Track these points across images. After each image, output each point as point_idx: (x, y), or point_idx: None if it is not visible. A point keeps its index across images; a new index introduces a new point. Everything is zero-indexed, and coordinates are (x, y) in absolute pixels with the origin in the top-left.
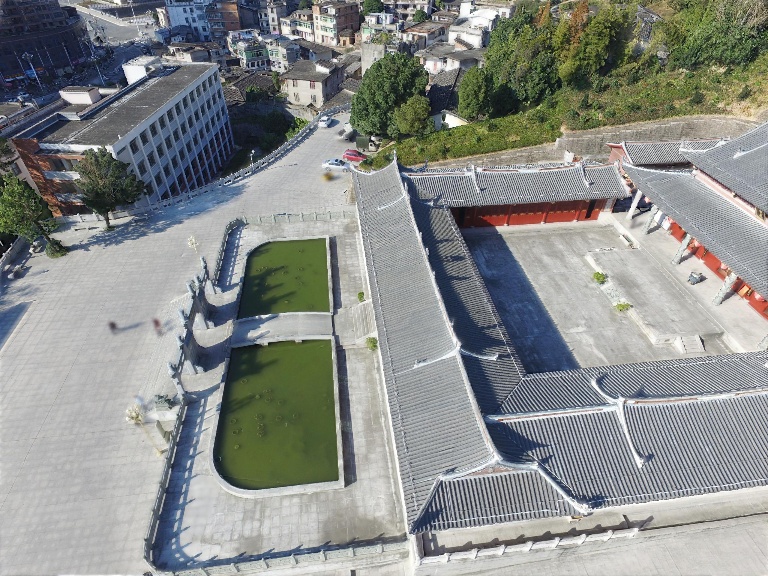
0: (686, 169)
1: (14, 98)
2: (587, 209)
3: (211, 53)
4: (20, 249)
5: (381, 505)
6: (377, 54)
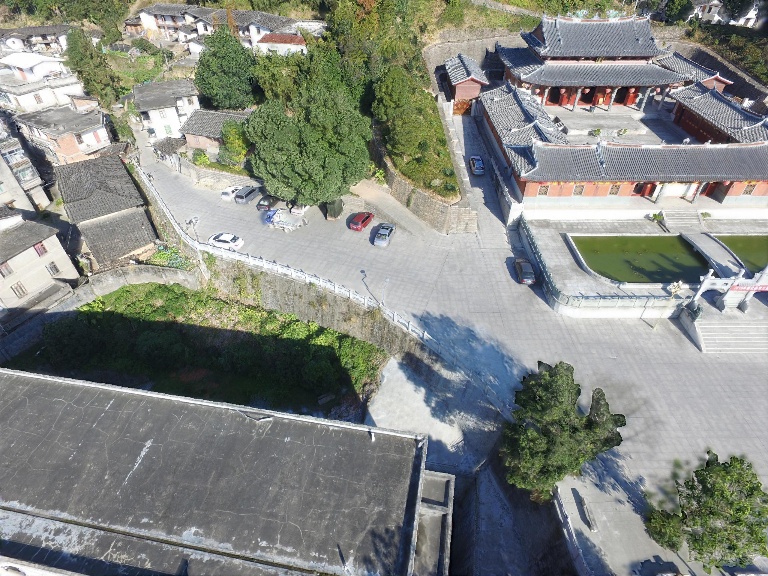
0: (515, 69)
1: None
2: None
3: None
4: None
5: None
6: None
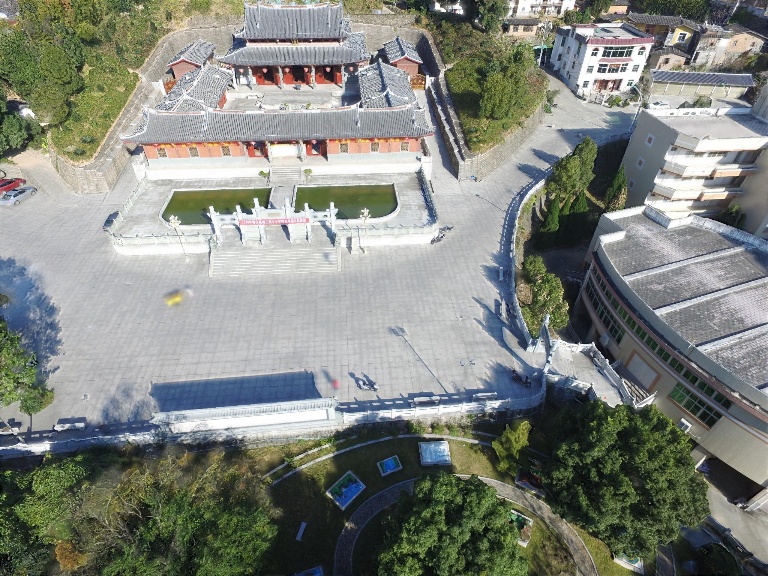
0: (229, 52)
1: None
2: (223, 94)
3: None
4: None
5: (403, 177)
6: None
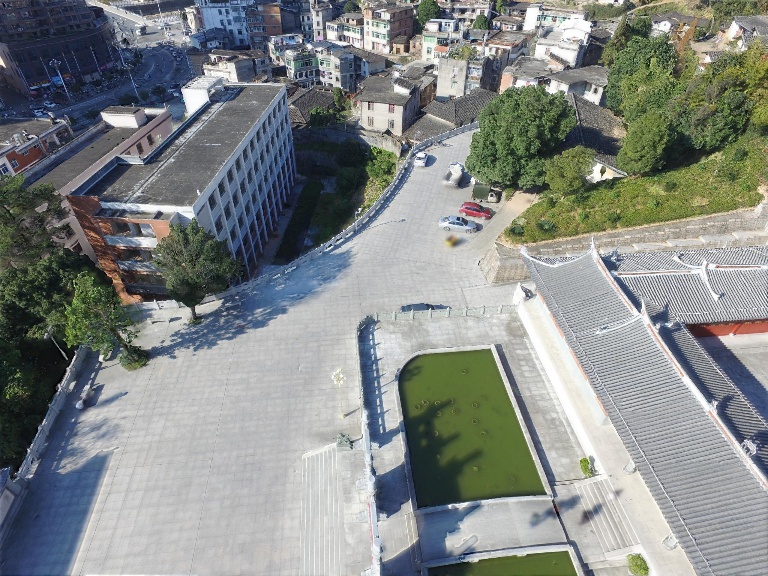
0: None
1: (40, 108)
2: None
3: (256, 62)
4: (85, 354)
5: None
6: (457, 71)
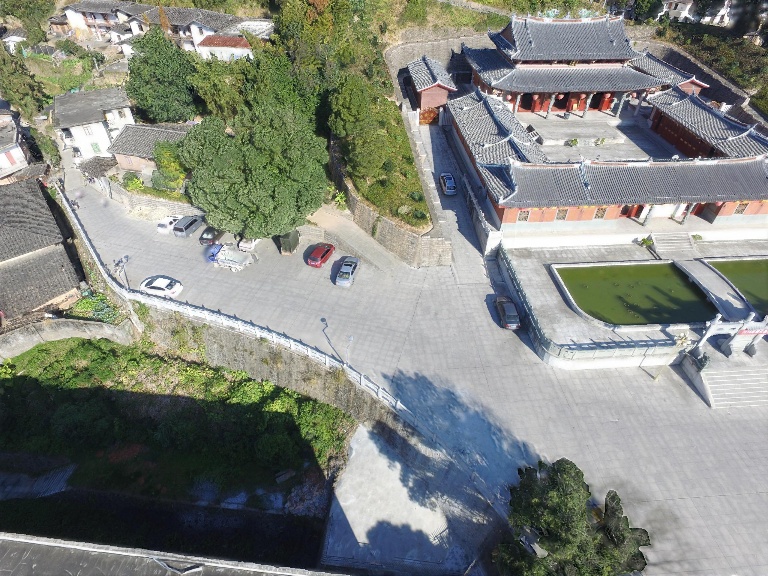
0: (484, 74)
1: None
2: None
3: None
4: None
5: None
6: None
